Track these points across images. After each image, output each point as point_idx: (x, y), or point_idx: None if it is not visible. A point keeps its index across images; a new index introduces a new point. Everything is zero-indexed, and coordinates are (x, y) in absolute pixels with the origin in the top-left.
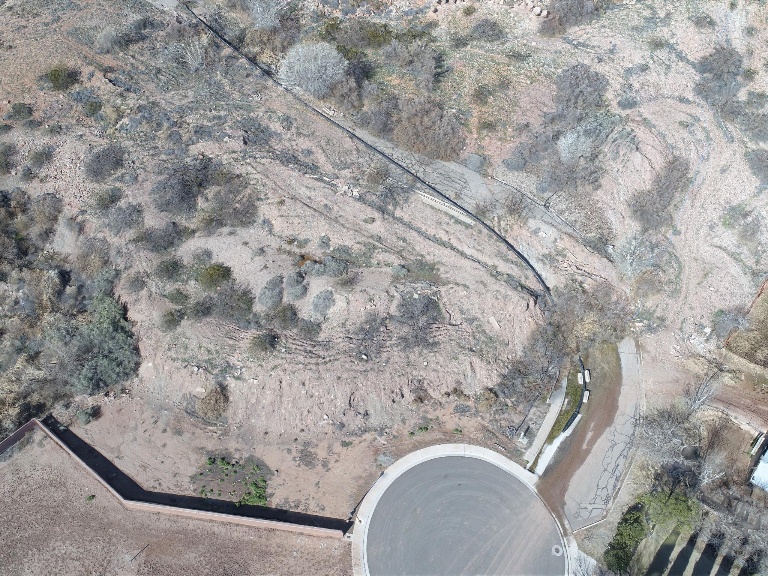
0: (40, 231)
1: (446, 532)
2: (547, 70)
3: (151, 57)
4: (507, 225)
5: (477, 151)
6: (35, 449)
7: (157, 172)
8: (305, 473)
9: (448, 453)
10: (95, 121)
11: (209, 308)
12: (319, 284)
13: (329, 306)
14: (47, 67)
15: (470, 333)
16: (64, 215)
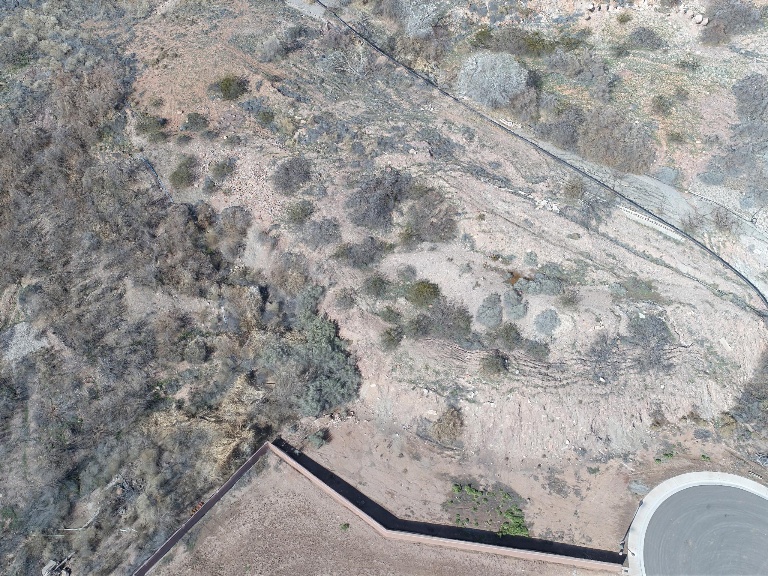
0: (231, 245)
1: (727, 566)
2: (721, 80)
3: (311, 66)
4: (719, 242)
5: (668, 164)
6: (273, 474)
7: (347, 185)
8: (559, 502)
9: (703, 481)
10: (270, 132)
11: (426, 327)
12: (539, 303)
13: (555, 326)
14: (215, 76)
15: (702, 355)
16: (254, 229)
